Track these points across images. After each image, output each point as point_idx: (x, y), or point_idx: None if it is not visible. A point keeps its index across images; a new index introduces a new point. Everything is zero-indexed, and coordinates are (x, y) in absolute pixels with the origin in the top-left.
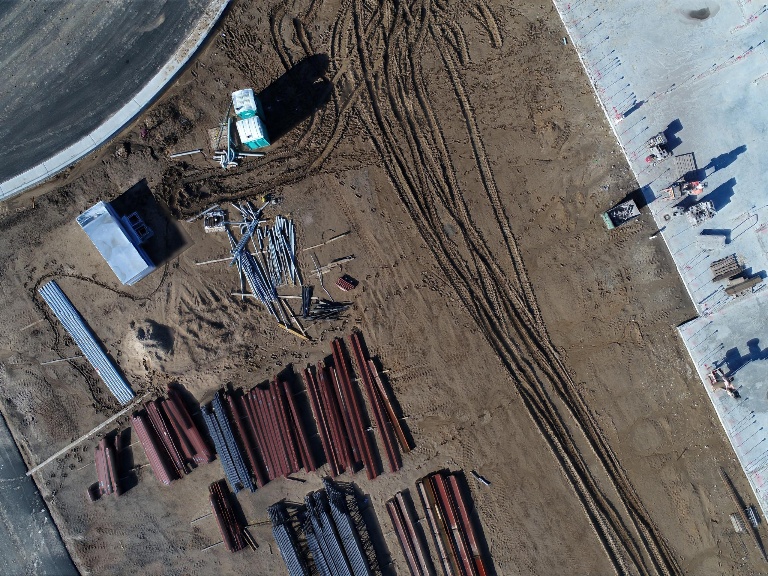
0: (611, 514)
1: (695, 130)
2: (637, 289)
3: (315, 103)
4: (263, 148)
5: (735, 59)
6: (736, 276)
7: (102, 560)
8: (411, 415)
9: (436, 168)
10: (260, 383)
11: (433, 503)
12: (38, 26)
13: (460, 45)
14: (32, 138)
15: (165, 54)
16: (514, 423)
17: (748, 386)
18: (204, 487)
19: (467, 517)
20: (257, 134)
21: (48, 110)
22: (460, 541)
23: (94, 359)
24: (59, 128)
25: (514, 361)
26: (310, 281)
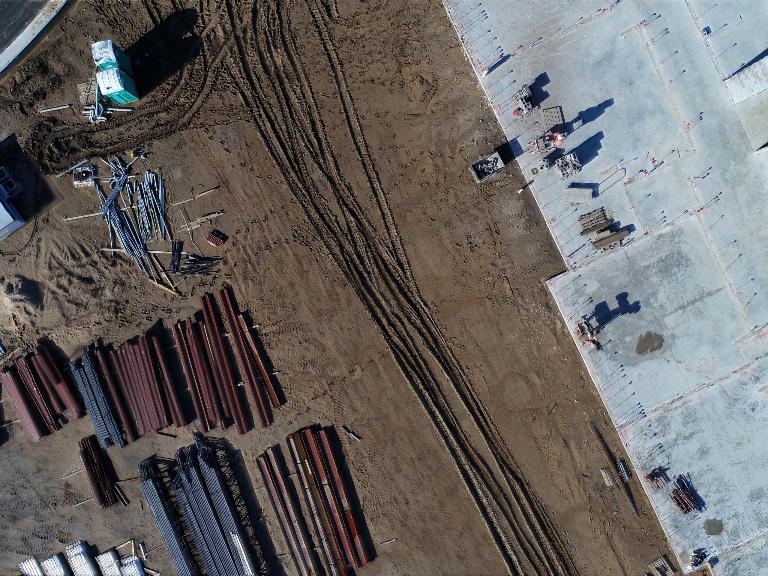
0: (482, 469)
1: (562, 83)
2: (506, 243)
3: (184, 58)
4: (132, 103)
5: (602, 12)
6: (603, 229)
7: None
8: (282, 370)
9: (305, 123)
10: (130, 338)
11: (303, 458)
12: None
13: None
14: None
15: (34, 9)
16: (385, 378)
17: (617, 340)
18: (75, 443)
19: (337, 472)
20: (117, 86)
21: None
22: (331, 496)
23: None
24: None
25: (384, 316)
26: (180, 236)
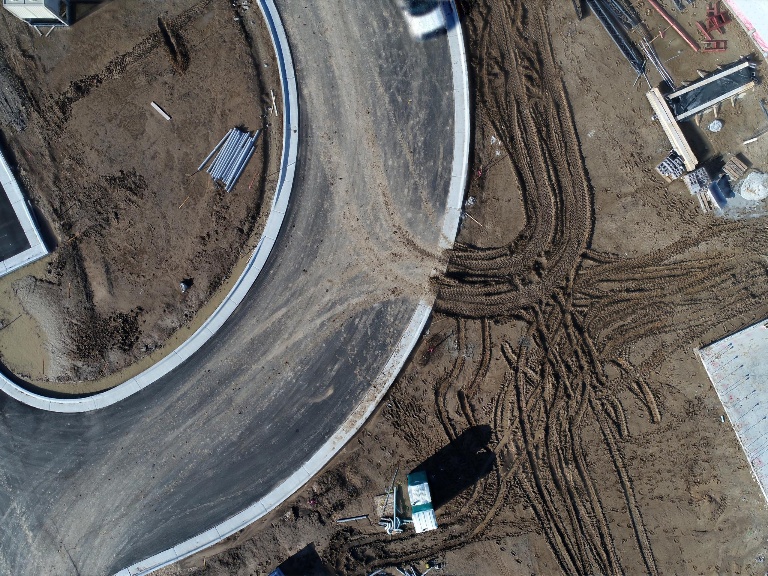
0: None
1: None
2: None
3: (478, 473)
4: None
5: None
6: None
7: None
8: None
9: (594, 536)
10: None
11: None
12: (212, 396)
13: (619, 419)
14: (205, 502)
15: (333, 424)
16: None
17: None
18: None
19: None
20: (432, 527)
21: (220, 476)
22: None
23: None
24: (231, 493)
25: None
26: None
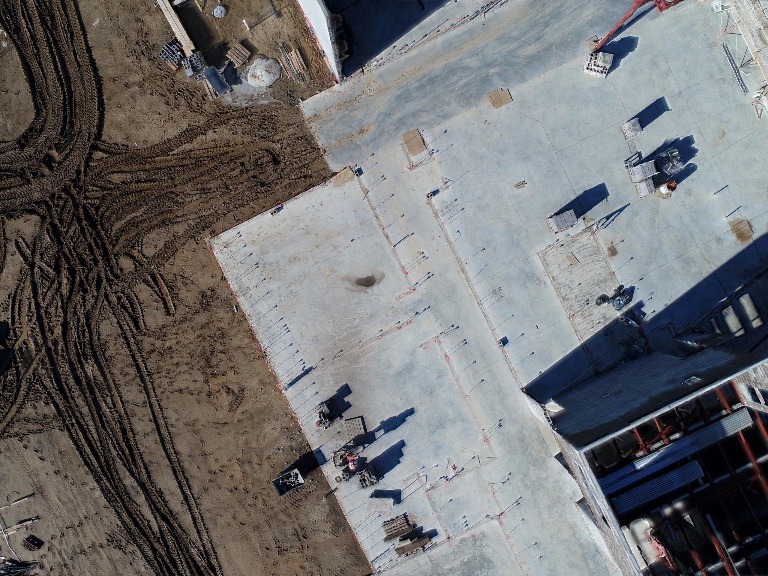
0: None
1: (364, 394)
2: (313, 547)
3: None
4: None
5: (401, 325)
6: (405, 536)
7: None
8: None
9: (116, 431)
10: None
11: None
12: None
13: (136, 312)
14: None
15: None
16: None
17: None
18: None
19: None
20: None
21: None
22: None
23: None
24: None
25: None
26: None
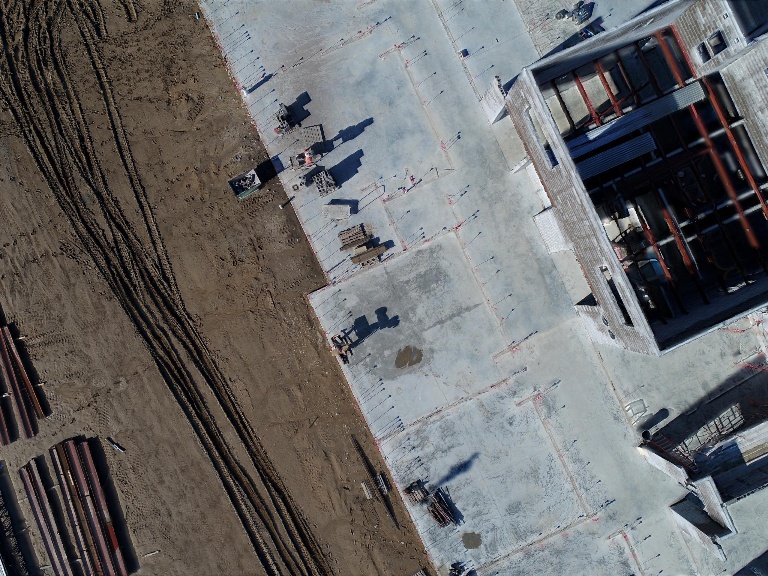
0: (246, 481)
1: (323, 103)
2: (269, 258)
3: None
4: None
5: (361, 34)
6: (361, 245)
7: None
8: (48, 381)
9: (74, 138)
10: None
11: (66, 469)
12: None
13: (98, 19)
14: None
15: None
16: (149, 390)
17: (376, 354)
18: None
19: (99, 483)
20: None
21: None
22: (93, 507)
23: None
24: None
25: (149, 328)
26: None
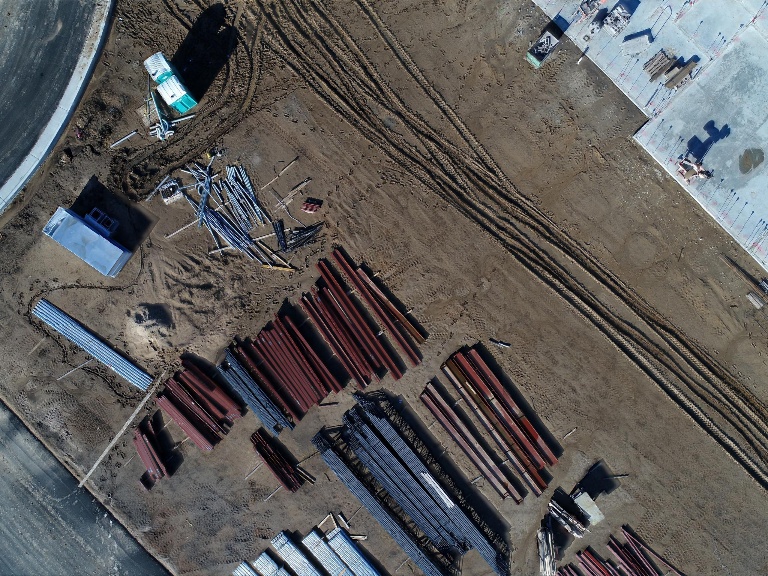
0: (634, 334)
1: None
2: (583, 115)
3: (225, 51)
4: (192, 109)
5: None
6: (670, 69)
7: (176, 543)
8: (414, 307)
9: (357, 70)
10: (264, 326)
11: (464, 381)
12: None
13: None
14: None
15: (73, 55)
16: (513, 281)
17: (719, 168)
18: (246, 441)
19: (500, 383)
20: (179, 91)
21: None
22: (501, 408)
23: (104, 357)
24: (0, 157)
25: (492, 223)
26: (277, 216)
